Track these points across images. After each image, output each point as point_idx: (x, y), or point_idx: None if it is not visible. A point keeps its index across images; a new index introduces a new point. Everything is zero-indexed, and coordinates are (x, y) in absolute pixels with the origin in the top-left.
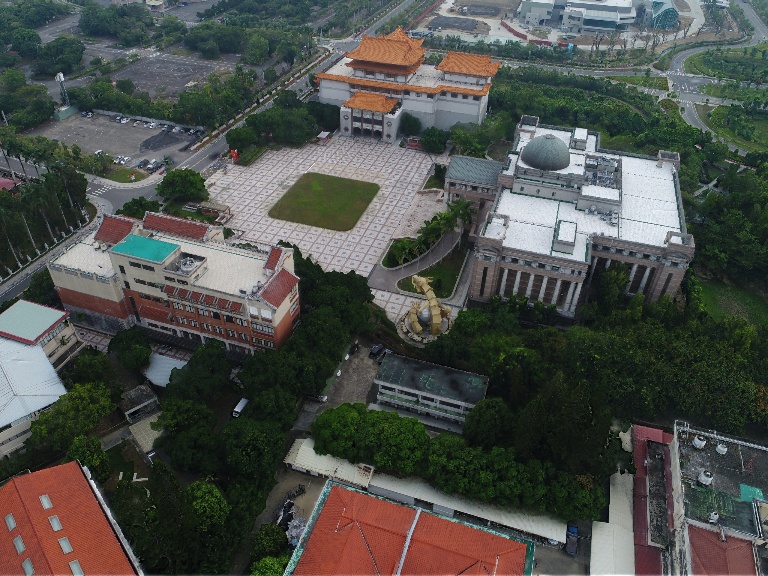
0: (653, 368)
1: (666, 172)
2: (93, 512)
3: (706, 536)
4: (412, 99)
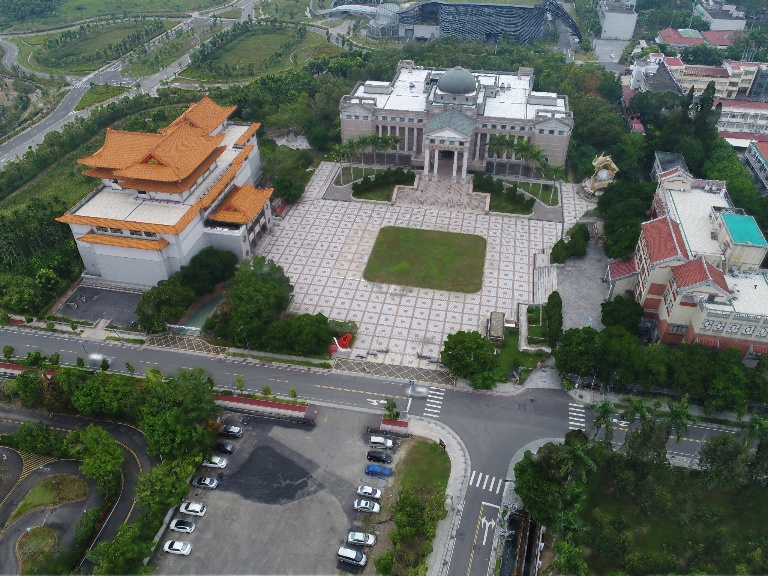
0: None
1: (419, 71)
2: None
3: (716, 104)
4: (238, 174)
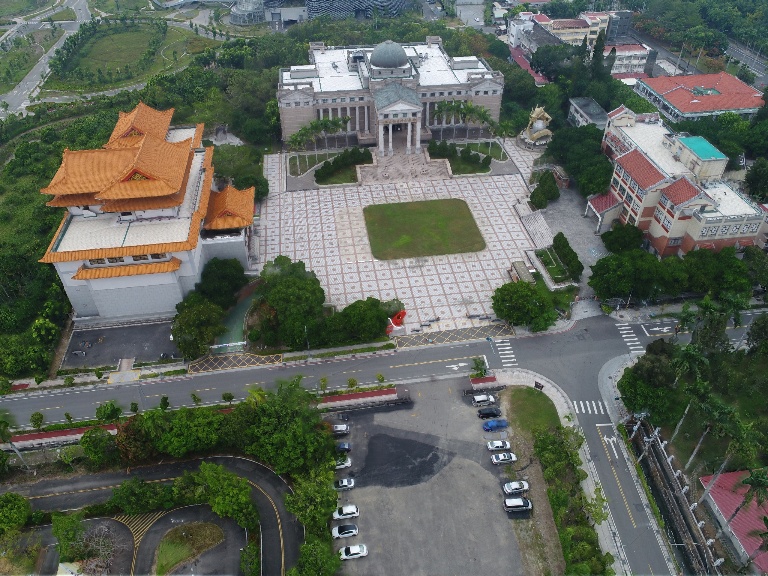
0: (516, 65)
1: (331, 51)
2: None
3: None
4: None
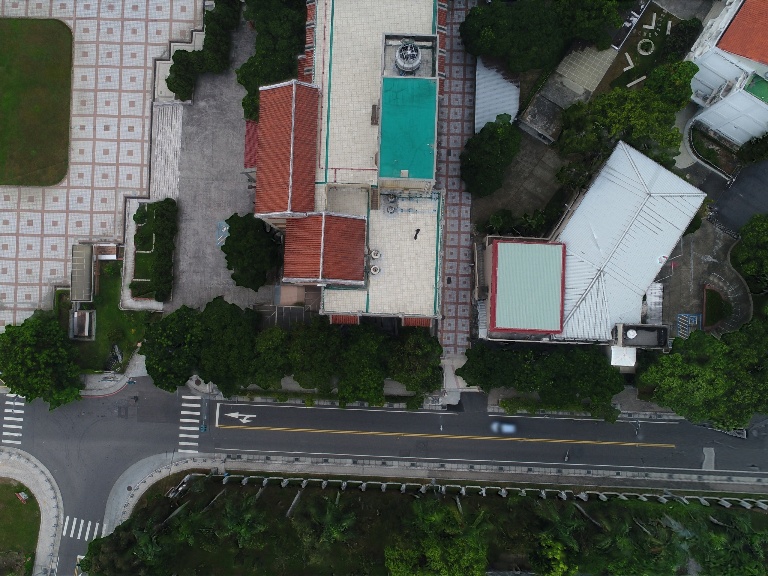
0: None
1: None
2: None
3: None
4: None
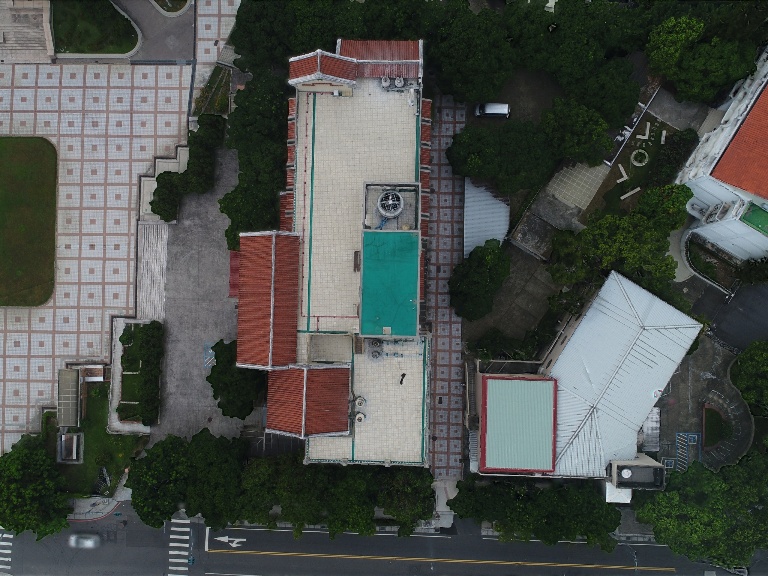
0: None
1: None
2: (762, 110)
3: None
4: None
